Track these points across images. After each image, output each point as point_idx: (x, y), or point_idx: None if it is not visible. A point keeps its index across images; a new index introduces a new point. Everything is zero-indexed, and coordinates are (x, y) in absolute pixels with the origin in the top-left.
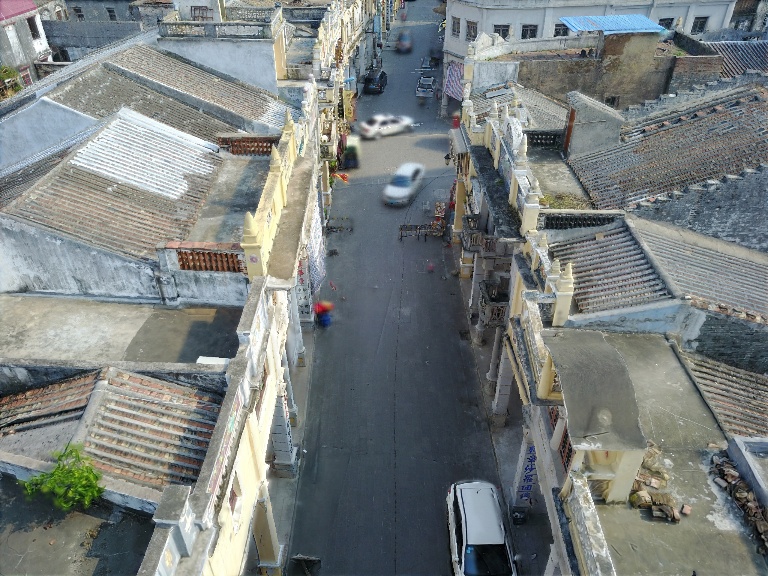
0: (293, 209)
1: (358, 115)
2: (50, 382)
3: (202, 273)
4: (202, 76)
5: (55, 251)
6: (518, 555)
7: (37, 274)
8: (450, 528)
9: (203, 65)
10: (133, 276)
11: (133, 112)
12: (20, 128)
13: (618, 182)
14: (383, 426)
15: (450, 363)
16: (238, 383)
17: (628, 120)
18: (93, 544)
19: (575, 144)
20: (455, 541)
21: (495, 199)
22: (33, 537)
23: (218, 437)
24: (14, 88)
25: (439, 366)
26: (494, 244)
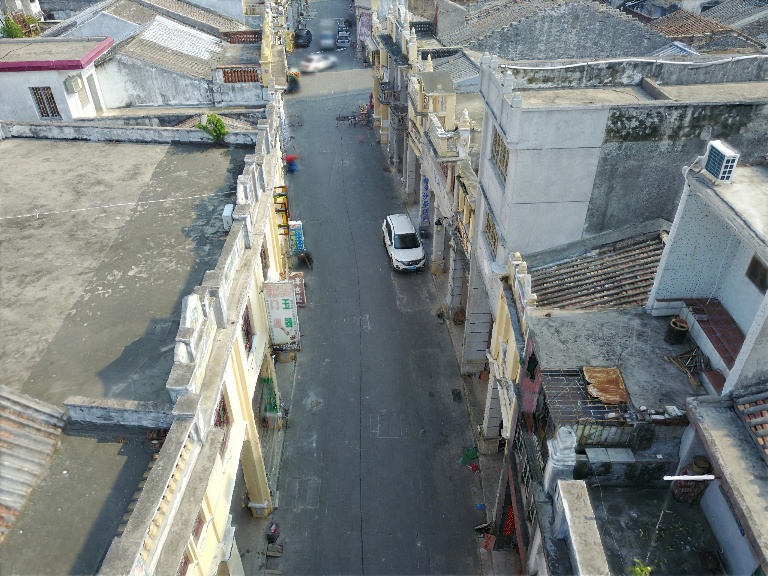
0: (277, 63)
1: (293, 61)
2: (171, 126)
3: (236, 84)
4: (192, 8)
5: (151, 76)
6: (424, 249)
7: (138, 93)
8: (385, 237)
9: (190, 2)
10: (196, 90)
11: (164, 18)
12: (85, 34)
13: (463, 41)
14: (340, 210)
15: (378, 182)
16: (273, 111)
17: (470, 12)
18: (226, 154)
19: (440, 26)
20: (388, 238)
21: (395, 53)
22: (198, 154)
23: (271, 122)
24: (35, 32)
25: (372, 184)
26: (399, 95)
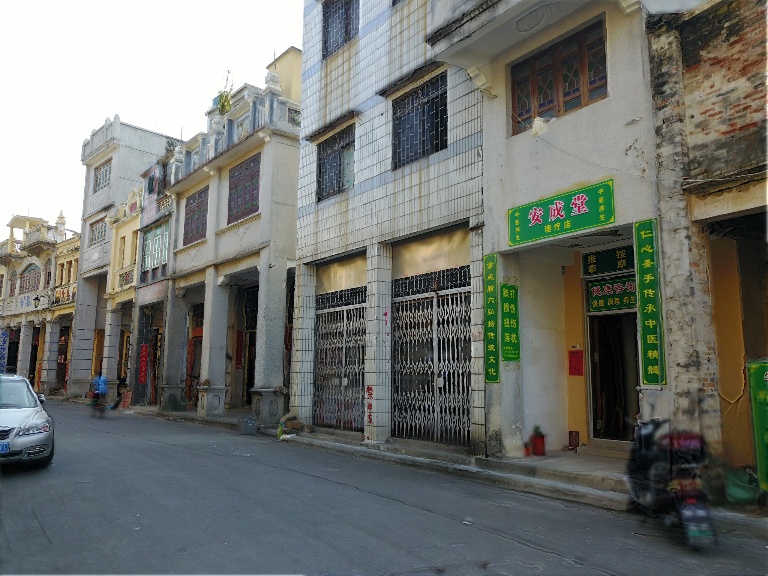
0: None
1: None
2: None
3: None
4: None
5: None
6: None
7: None
8: None
9: None
10: None
11: None
12: None
13: None
14: None
15: None
16: None
17: None
18: None
19: None
20: None
21: None
22: None
23: None
24: None
25: None
26: None
